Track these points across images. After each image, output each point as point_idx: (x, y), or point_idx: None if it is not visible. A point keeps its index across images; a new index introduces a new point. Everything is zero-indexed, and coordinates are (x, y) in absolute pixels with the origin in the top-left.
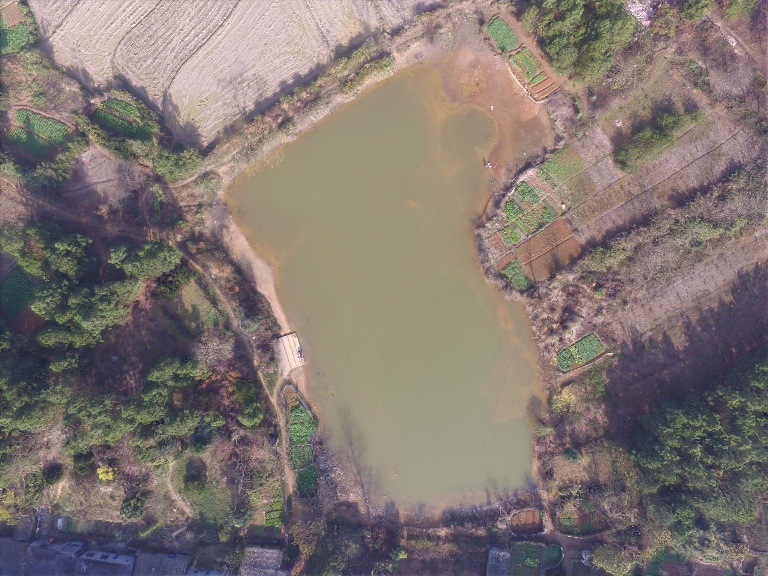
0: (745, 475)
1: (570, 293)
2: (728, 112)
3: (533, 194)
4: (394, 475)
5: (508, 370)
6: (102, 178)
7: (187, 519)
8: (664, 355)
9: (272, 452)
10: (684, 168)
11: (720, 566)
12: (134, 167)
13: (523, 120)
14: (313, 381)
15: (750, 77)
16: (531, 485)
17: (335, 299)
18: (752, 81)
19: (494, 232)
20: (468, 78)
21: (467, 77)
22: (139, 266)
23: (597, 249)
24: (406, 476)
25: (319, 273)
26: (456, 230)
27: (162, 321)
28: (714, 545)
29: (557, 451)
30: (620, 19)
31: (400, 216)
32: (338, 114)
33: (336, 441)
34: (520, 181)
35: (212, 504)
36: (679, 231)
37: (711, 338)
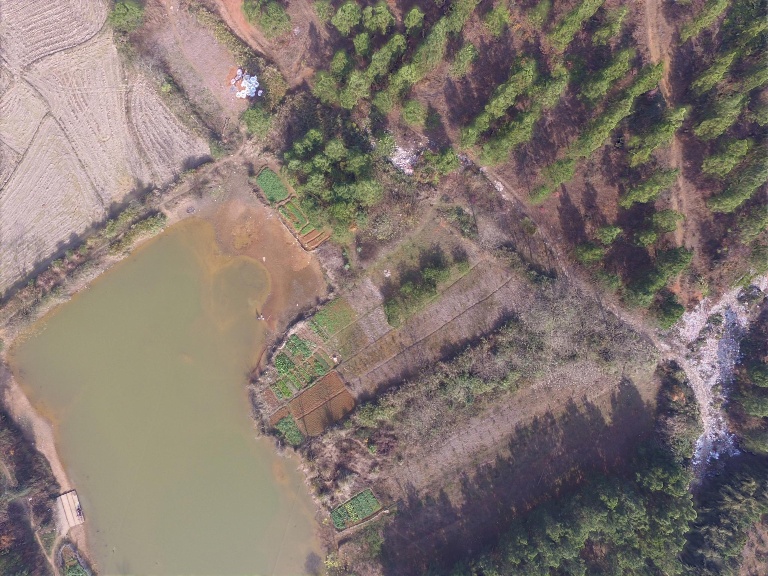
0: None
1: (343, 449)
2: (497, 260)
3: (304, 347)
4: None
5: (286, 526)
6: None
7: None
8: (441, 513)
9: None
10: (455, 319)
11: None
12: None
13: (295, 270)
14: (93, 538)
15: (519, 223)
16: None
17: (114, 455)
18: (521, 227)
19: (266, 387)
20: (240, 230)
21: (239, 229)
22: None
23: (365, 406)
24: None
25: (98, 430)
26: (231, 384)
27: None
28: None
29: None
30: None
31: (175, 371)
32: (113, 271)
33: None
34: (291, 334)
35: None
36: (451, 385)
37: (489, 496)
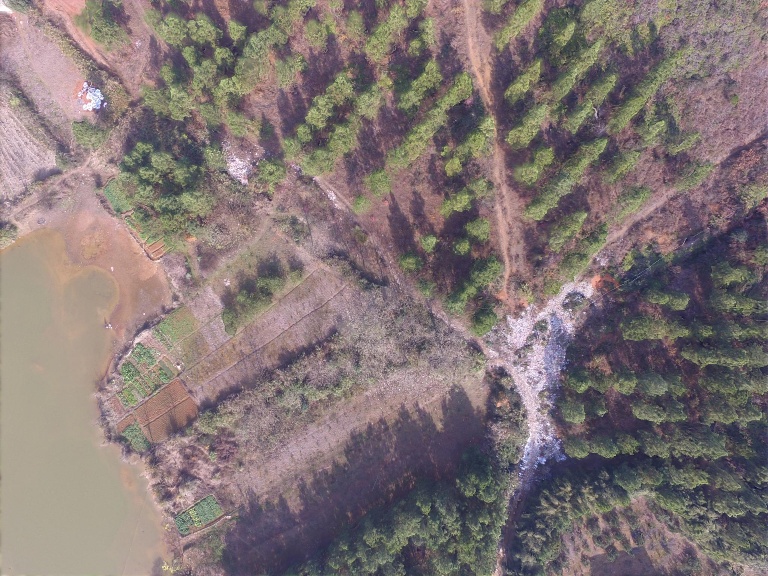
0: None
1: (186, 456)
2: (331, 269)
3: (149, 356)
4: None
5: (134, 532)
6: None
7: None
8: (280, 519)
9: None
10: (292, 326)
11: None
12: None
13: (142, 280)
14: None
15: (350, 232)
16: None
17: None
18: (353, 236)
19: (113, 395)
20: (89, 240)
21: (88, 239)
22: None
23: (205, 413)
24: None
25: None
26: (81, 392)
27: None
28: None
29: None
30: (186, 192)
31: (27, 380)
32: None
33: None
34: (136, 343)
35: None
36: (287, 392)
37: (326, 501)
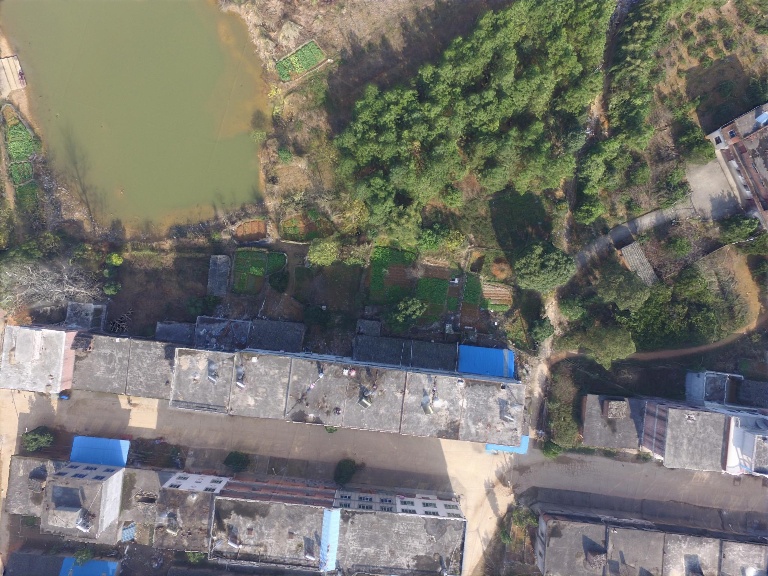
0: (439, 144)
1: (287, 1)
2: None
3: None
4: (120, 193)
5: (232, 85)
6: None
7: None
8: (383, 58)
9: None
10: None
11: (448, 267)
12: None
13: None
14: (36, 103)
15: None
16: (259, 199)
17: (57, 23)
18: None
19: None
20: None
21: None
22: None
23: None
24: (132, 194)
25: None
26: None
27: None
28: (415, 220)
29: (281, 161)
30: None
31: None
32: None
33: (61, 162)
34: None
35: None
36: None
37: (429, 37)
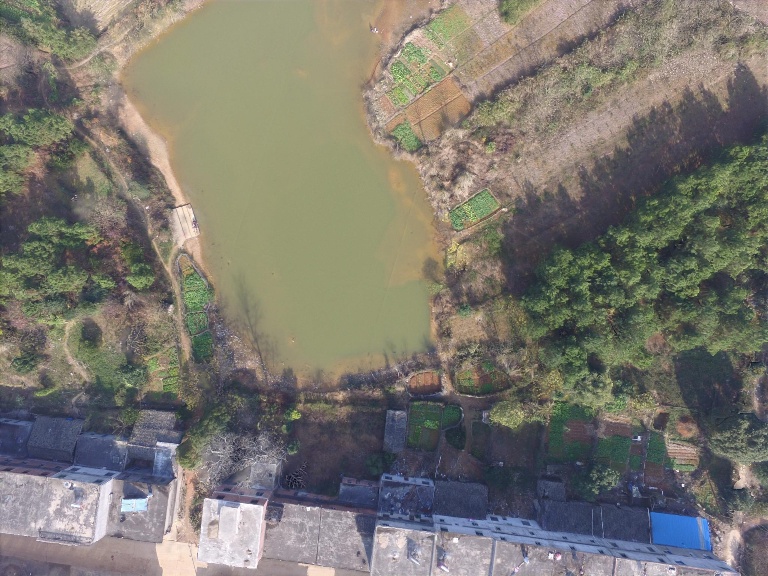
0: (637, 312)
1: (460, 150)
2: None
3: (419, 54)
4: (291, 341)
5: (402, 233)
6: (4, 64)
7: (84, 383)
8: (560, 207)
9: (168, 319)
10: (571, 16)
11: (630, 424)
12: (33, 53)
13: None
14: (208, 251)
15: None
16: (430, 348)
17: (228, 170)
18: None
19: (382, 95)
20: None
21: None
22: (24, 129)
23: (484, 102)
24: (303, 342)
25: (212, 146)
26: (345, 96)
27: (57, 192)
28: (610, 388)
29: (454, 311)
30: None
31: (289, 86)
32: None
33: (233, 309)
34: (406, 43)
35: (108, 369)
36: (568, 79)
37: (608, 187)
